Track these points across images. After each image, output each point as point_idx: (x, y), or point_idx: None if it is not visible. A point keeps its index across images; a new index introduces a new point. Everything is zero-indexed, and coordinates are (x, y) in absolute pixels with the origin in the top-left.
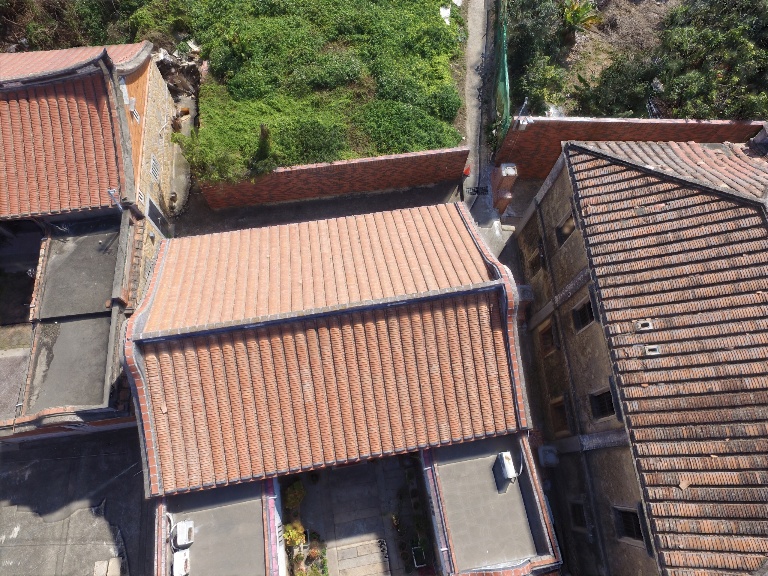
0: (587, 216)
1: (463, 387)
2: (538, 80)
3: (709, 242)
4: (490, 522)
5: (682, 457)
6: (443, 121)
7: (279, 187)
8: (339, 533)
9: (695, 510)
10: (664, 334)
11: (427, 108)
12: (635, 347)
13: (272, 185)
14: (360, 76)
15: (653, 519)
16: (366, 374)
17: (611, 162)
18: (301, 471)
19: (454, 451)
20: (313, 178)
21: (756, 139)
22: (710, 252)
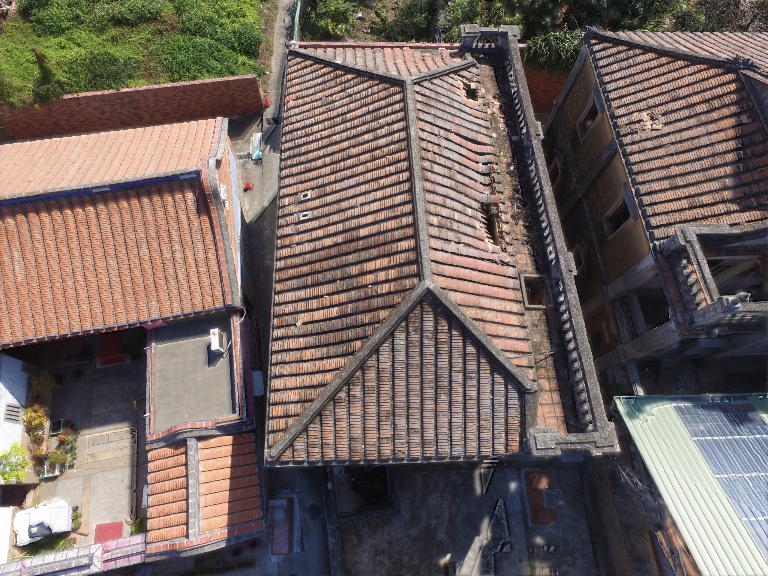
0: (288, 110)
1: (171, 269)
2: (326, 13)
3: (364, 119)
4: (195, 391)
5: (305, 301)
6: (243, 55)
7: (75, 116)
8: (94, 423)
9: (302, 342)
10: (317, 201)
11: (227, 43)
12: (294, 215)
13: (66, 114)
14: (162, 13)
15: (272, 354)
16: (76, 257)
17: (315, 62)
18: (12, 346)
19: (175, 333)
20: (106, 106)
21: (462, 43)
22: (363, 128)
